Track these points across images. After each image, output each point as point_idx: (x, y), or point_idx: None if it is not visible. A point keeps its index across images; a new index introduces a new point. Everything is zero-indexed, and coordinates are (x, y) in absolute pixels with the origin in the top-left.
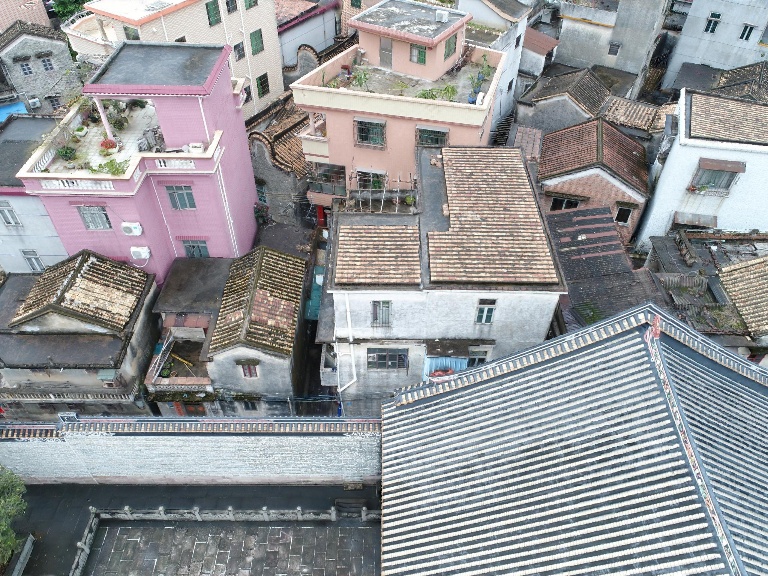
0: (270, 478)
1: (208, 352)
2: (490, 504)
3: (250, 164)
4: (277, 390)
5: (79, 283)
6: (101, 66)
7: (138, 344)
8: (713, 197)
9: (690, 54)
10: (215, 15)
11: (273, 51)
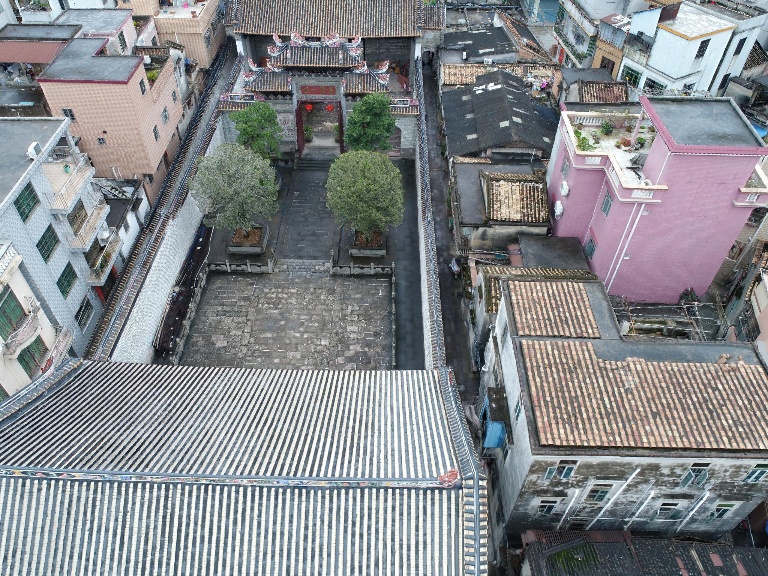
0: None
1: (484, 267)
2: None
3: (719, 259)
4: None
5: (515, 185)
6: (677, 96)
7: (492, 238)
8: None
9: None
10: None
11: None
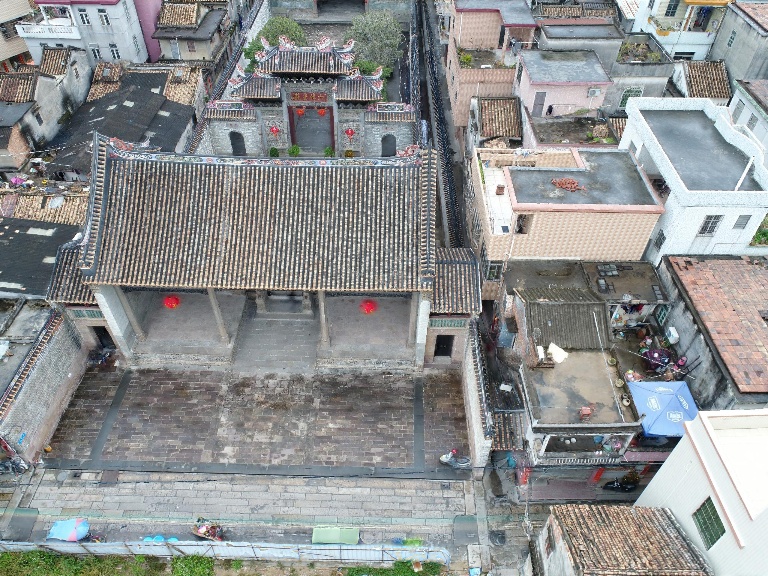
0: None
1: (225, 1)
2: None
3: None
4: None
5: None
6: None
7: None
8: None
9: None
10: None
11: None
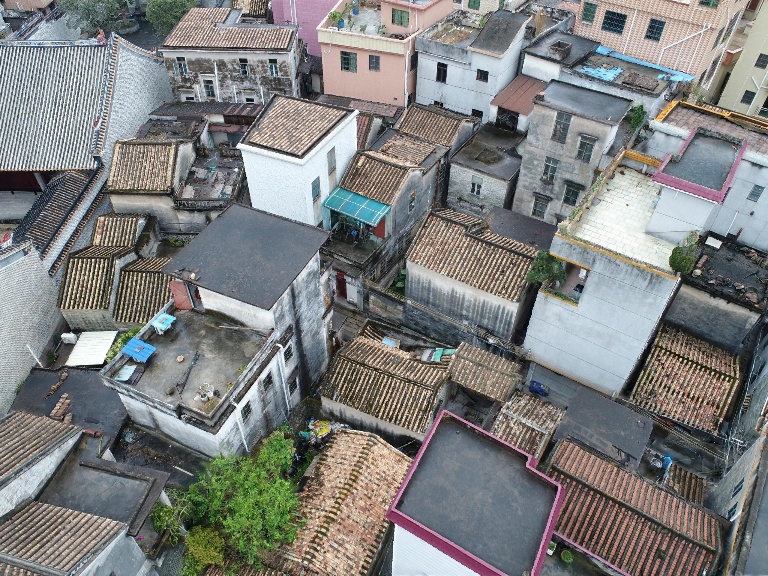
0: None
1: None
2: None
3: None
4: None
5: None
6: None
7: None
8: None
9: None
10: None
11: None
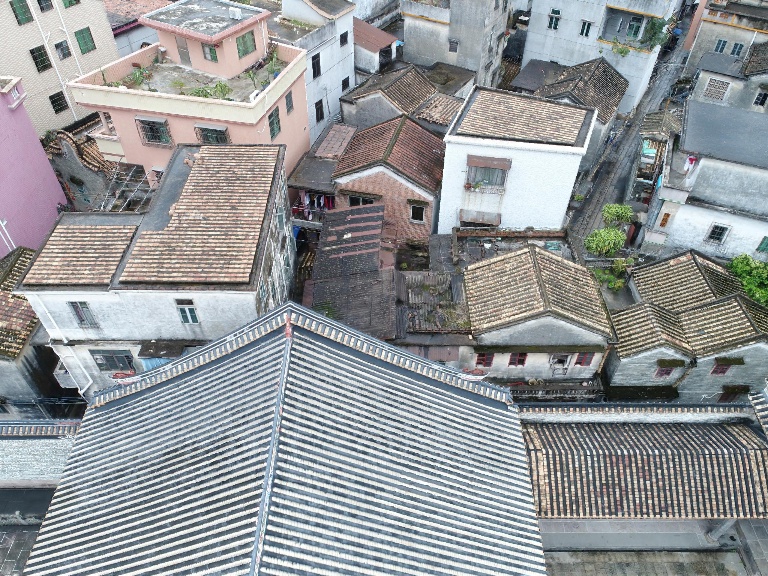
0: (12, 482)
1: None
2: (121, 508)
3: (46, 164)
4: (19, 393)
5: None
6: None
7: None
8: (492, 194)
9: (539, 51)
10: (24, 13)
11: (109, 50)
